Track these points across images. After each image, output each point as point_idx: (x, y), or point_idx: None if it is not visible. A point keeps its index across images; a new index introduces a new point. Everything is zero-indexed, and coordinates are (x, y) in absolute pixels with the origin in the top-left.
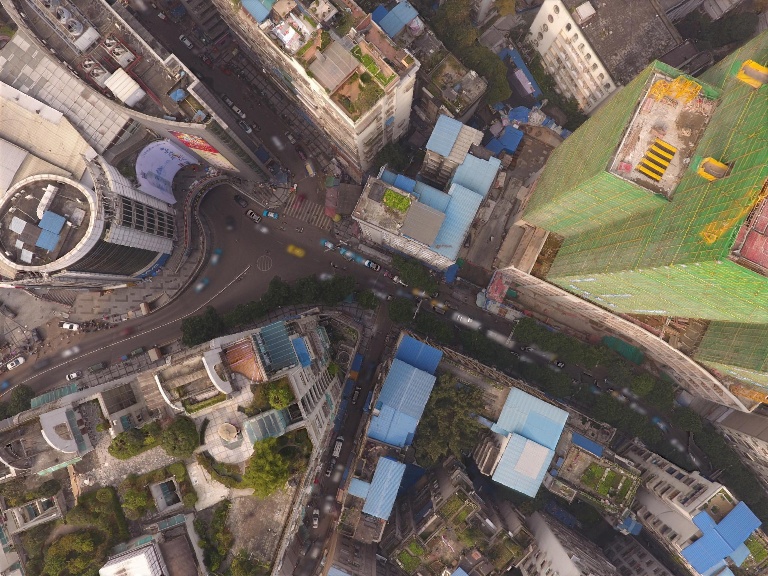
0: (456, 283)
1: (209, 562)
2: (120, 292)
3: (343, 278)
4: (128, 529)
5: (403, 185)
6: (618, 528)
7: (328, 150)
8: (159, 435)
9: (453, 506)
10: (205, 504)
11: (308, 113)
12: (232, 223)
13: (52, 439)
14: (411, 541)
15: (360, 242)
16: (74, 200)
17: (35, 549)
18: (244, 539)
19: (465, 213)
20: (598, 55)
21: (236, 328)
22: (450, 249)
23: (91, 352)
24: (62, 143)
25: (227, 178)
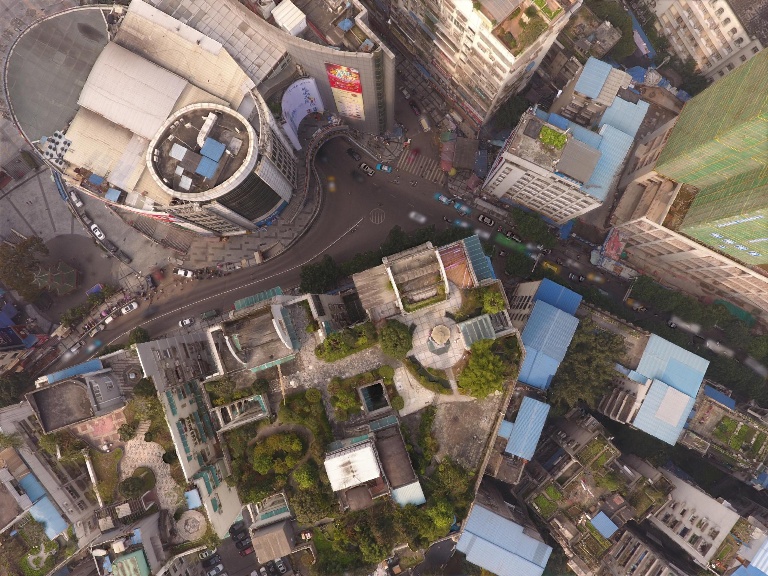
0: (569, 241)
1: (417, 465)
2: (234, 240)
3: (463, 229)
4: (331, 432)
5: (556, 123)
6: (752, 483)
7: (441, 106)
8: (372, 336)
9: (596, 449)
10: (409, 410)
11: (436, 62)
12: (345, 176)
13: (280, 330)
14: (548, 485)
15: (474, 197)
16: (231, 130)
17: (242, 447)
18: (449, 445)
19: (615, 154)
20: (733, 9)
21: (349, 279)
22: (600, 190)
23: (204, 299)
24: (220, 74)
25: (347, 128)
